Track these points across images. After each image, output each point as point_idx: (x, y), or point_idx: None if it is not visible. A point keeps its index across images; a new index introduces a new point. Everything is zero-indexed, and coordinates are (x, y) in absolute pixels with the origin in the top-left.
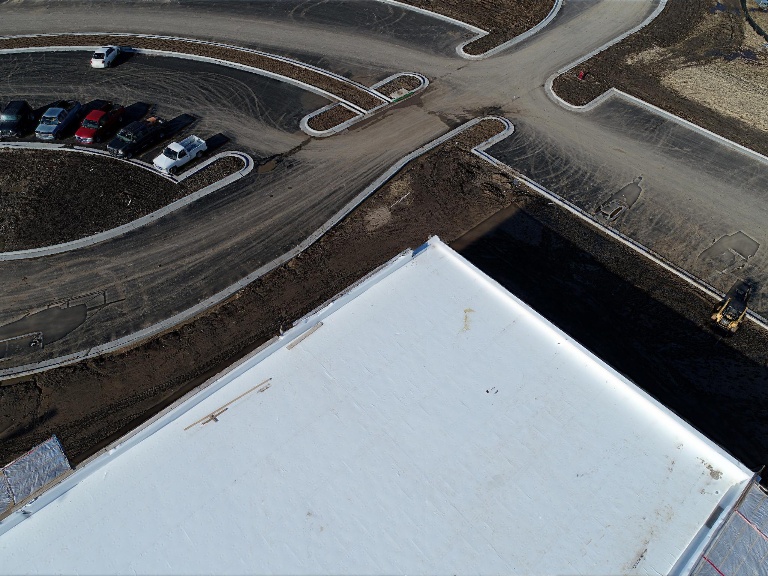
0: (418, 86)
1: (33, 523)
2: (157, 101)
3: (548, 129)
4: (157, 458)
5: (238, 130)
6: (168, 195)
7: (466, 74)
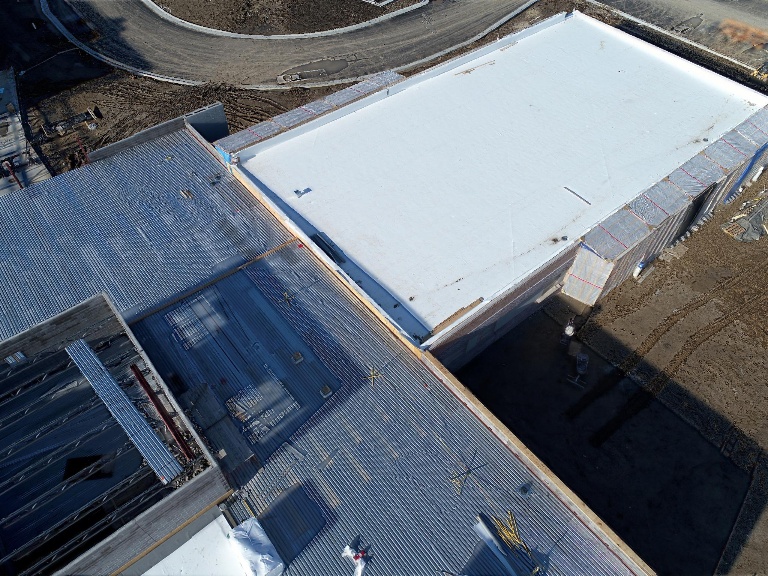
0: None
1: (389, 100)
2: None
3: None
4: (443, 84)
5: None
6: (377, 12)
7: None
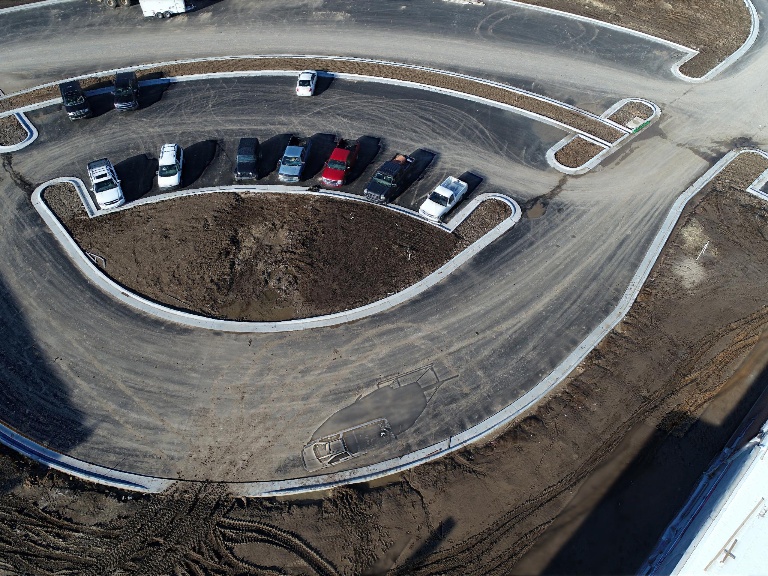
0: (651, 114)
1: None
2: (383, 134)
3: None
4: None
5: (485, 168)
6: (447, 247)
7: (695, 99)
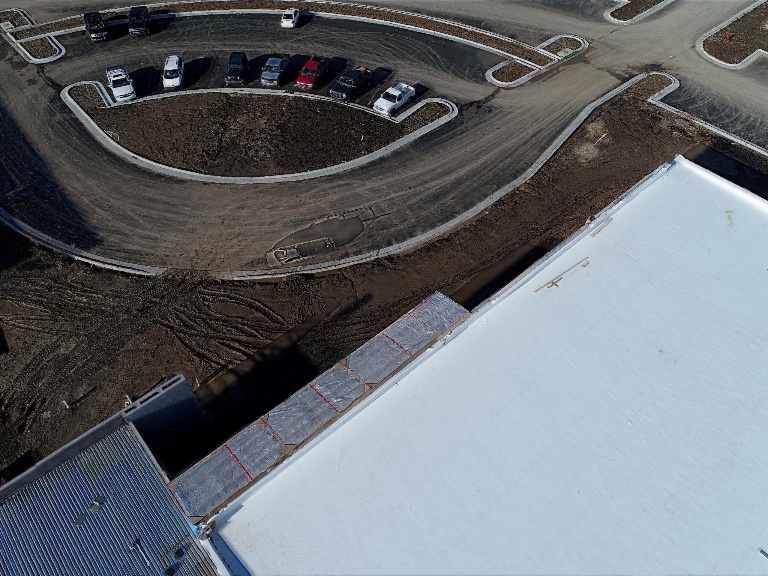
0: (580, 46)
1: (446, 352)
2: (351, 56)
3: (710, 83)
4: (522, 311)
5: (433, 81)
6: (394, 132)
7: (620, 37)
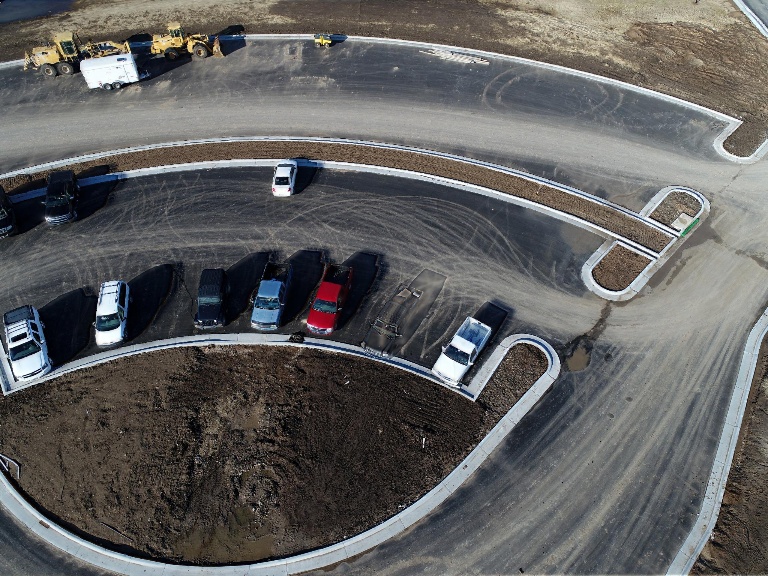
0: (699, 208)
1: None
2: (380, 249)
3: None
4: None
5: (509, 295)
6: (471, 424)
7: (748, 186)
